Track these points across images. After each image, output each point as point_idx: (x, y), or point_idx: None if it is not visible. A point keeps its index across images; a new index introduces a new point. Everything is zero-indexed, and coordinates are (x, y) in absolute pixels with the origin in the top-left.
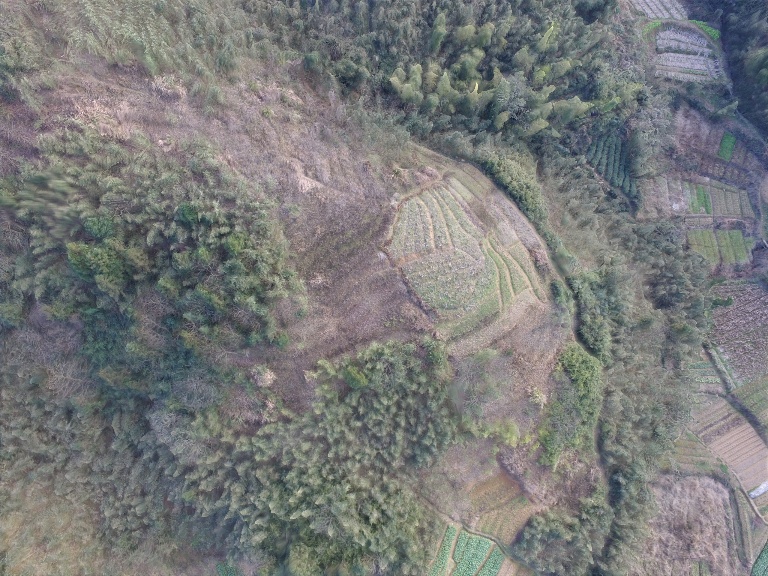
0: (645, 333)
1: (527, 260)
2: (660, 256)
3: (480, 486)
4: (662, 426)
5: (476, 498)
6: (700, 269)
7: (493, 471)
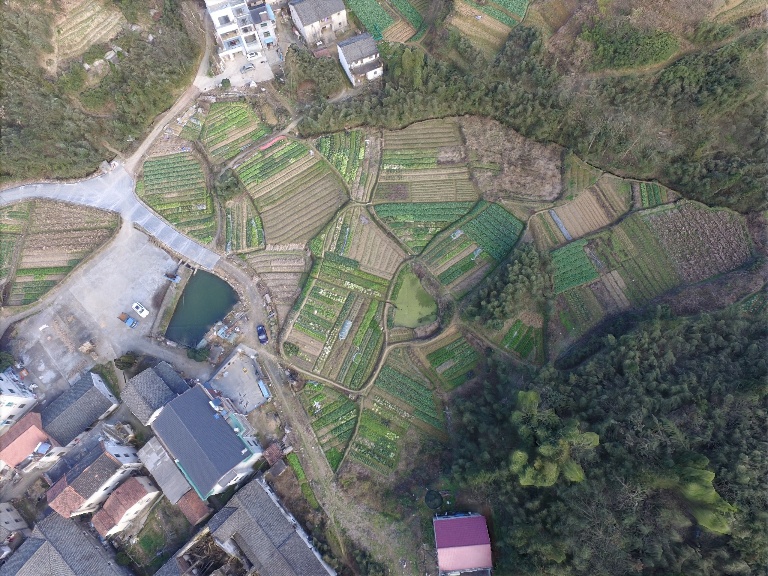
0: (694, 106)
1: (751, 6)
2: (767, 158)
3: (561, 3)
4: (611, 123)
5: (552, 4)
6: (761, 187)
7: (573, 7)
